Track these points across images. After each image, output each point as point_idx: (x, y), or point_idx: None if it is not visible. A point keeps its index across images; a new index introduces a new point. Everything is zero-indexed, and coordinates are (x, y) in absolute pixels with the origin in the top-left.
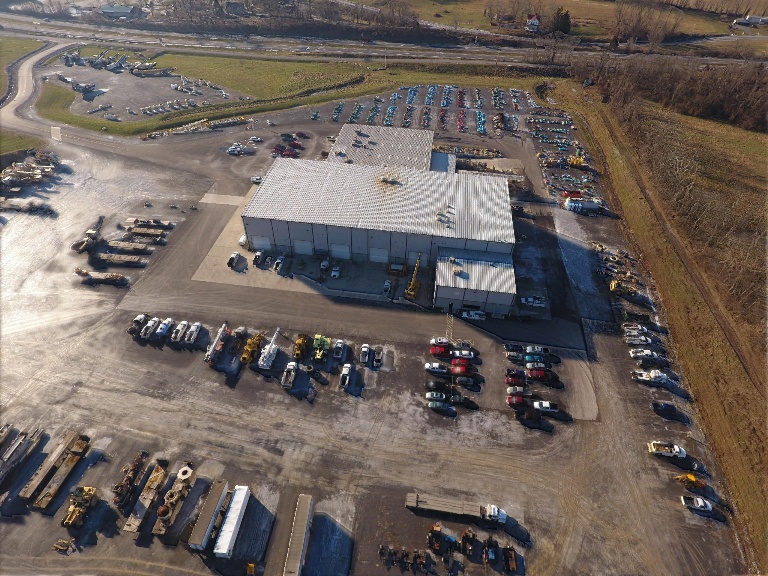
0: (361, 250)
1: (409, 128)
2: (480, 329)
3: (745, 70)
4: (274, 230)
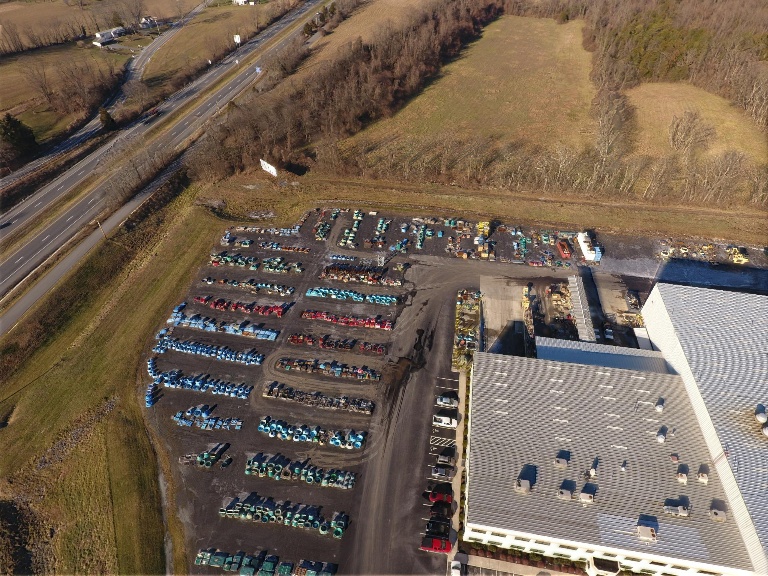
0: None
1: None
2: None
3: (322, 74)
4: None
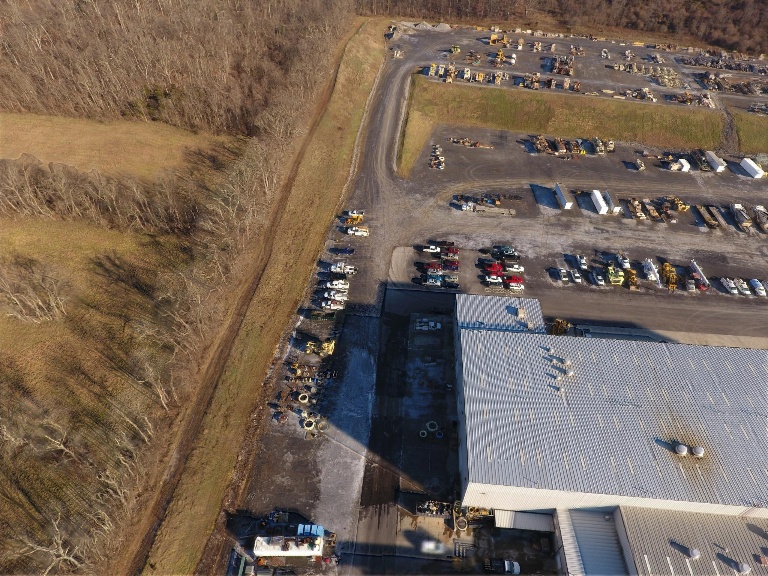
0: None
1: None
2: None
3: None
4: None
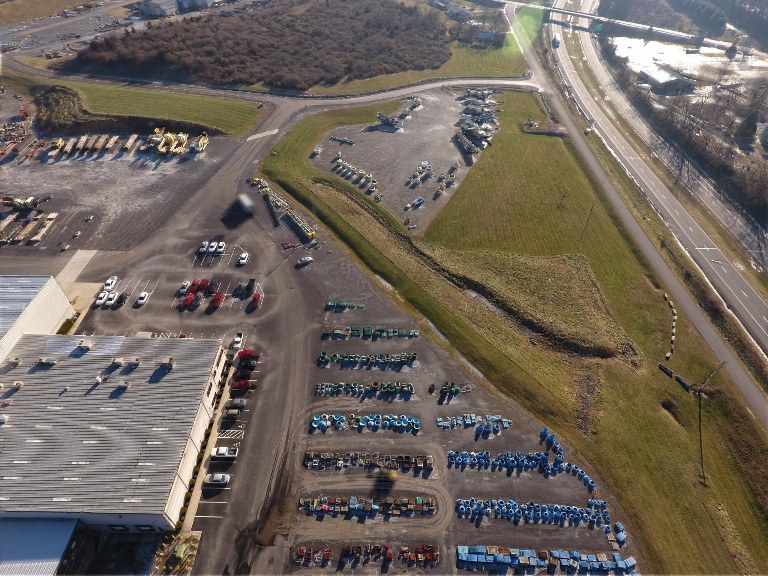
0: None
1: None
2: None
3: None
4: None
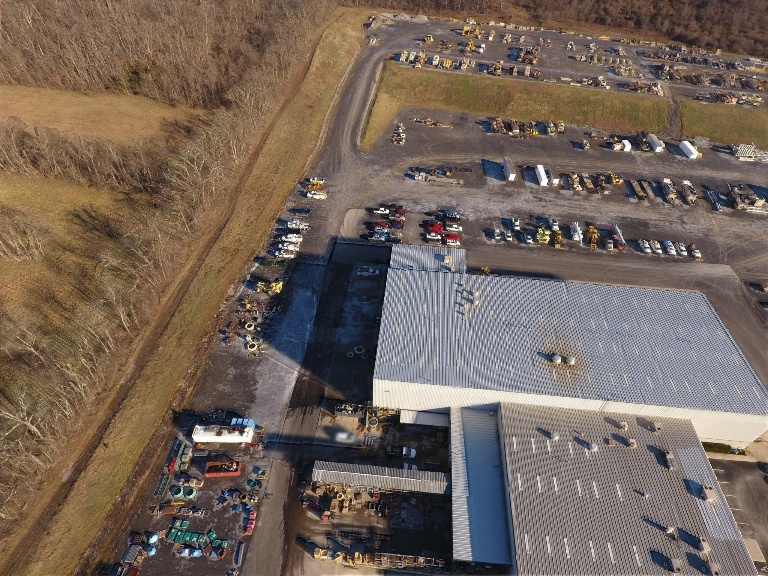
0: None
1: None
2: None
3: None
4: None
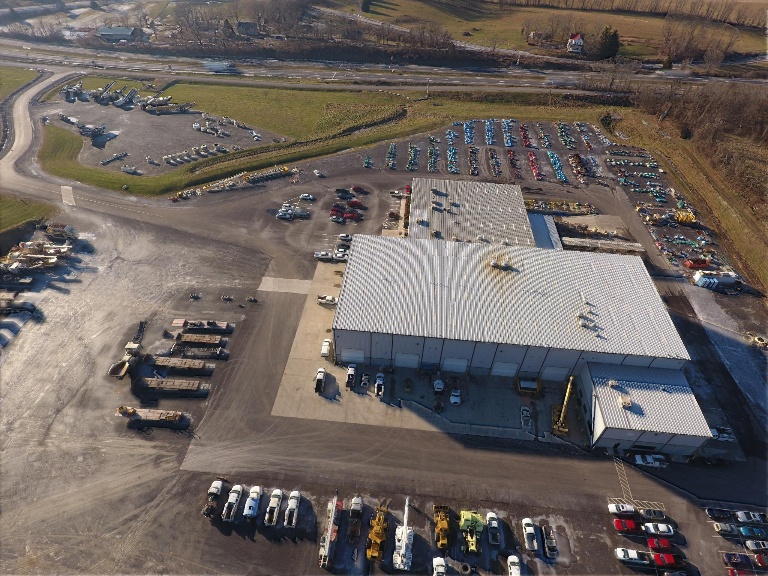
0: (483, 364)
1: (481, 177)
2: (664, 482)
3: None
4: (373, 343)
